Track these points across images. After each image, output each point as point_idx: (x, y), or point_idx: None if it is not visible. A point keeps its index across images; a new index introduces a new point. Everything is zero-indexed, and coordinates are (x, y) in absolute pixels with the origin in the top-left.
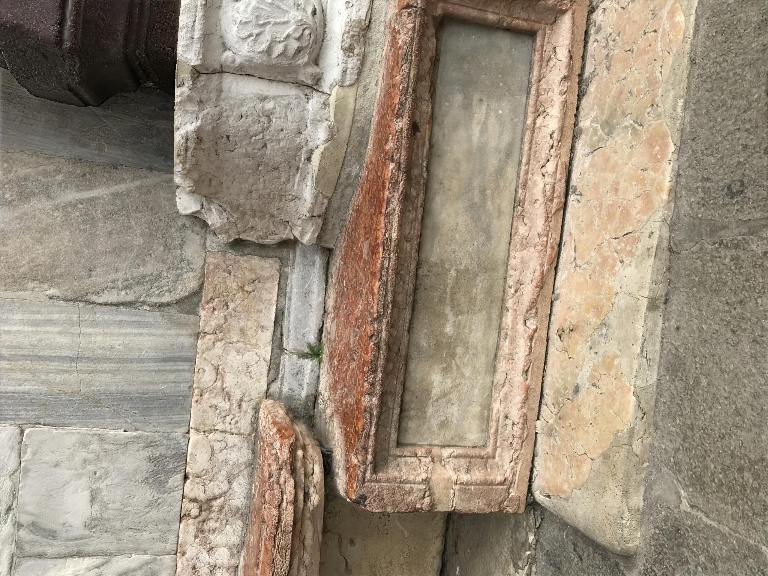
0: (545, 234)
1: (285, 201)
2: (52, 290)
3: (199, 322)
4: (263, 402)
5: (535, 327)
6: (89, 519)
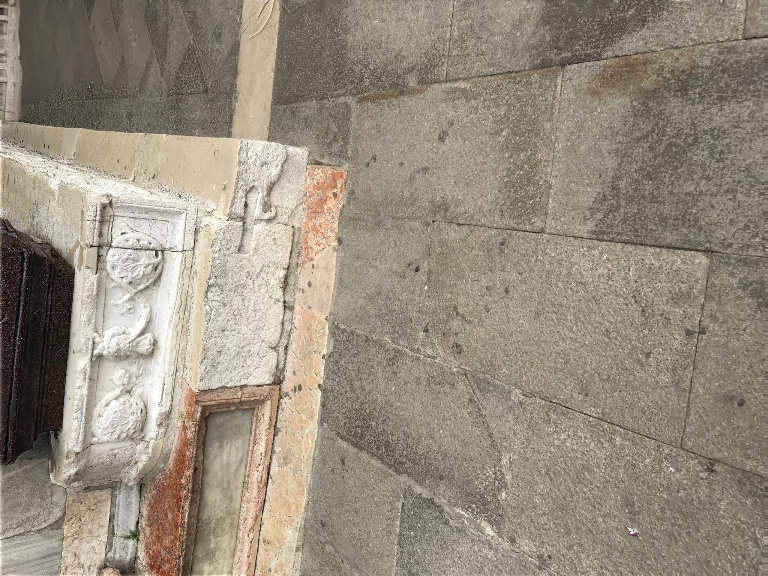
0: (258, 498)
1: (119, 474)
2: None
3: (63, 532)
4: (106, 570)
5: (253, 537)
6: None
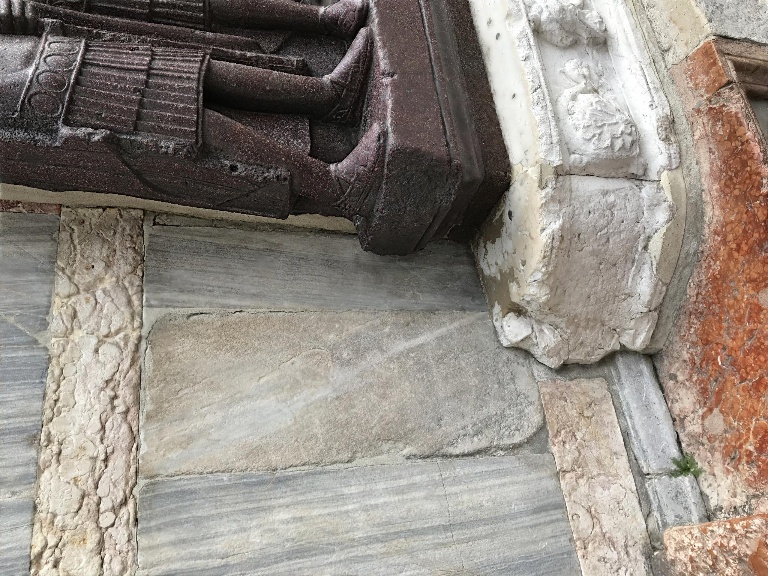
0: None
1: (617, 303)
2: (408, 448)
3: (554, 460)
4: (666, 532)
5: None
6: None
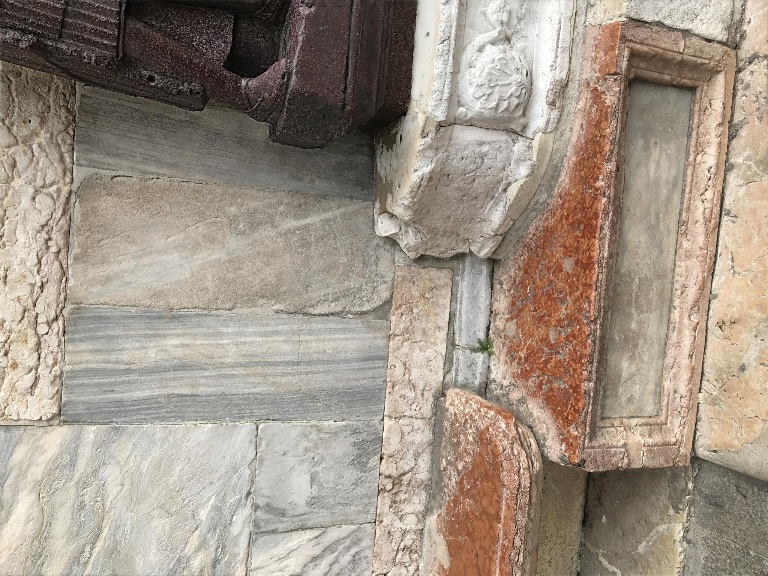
0: (705, 248)
1: (473, 223)
2: (277, 305)
3: (390, 326)
4: (450, 390)
5: (698, 321)
6: (310, 497)
